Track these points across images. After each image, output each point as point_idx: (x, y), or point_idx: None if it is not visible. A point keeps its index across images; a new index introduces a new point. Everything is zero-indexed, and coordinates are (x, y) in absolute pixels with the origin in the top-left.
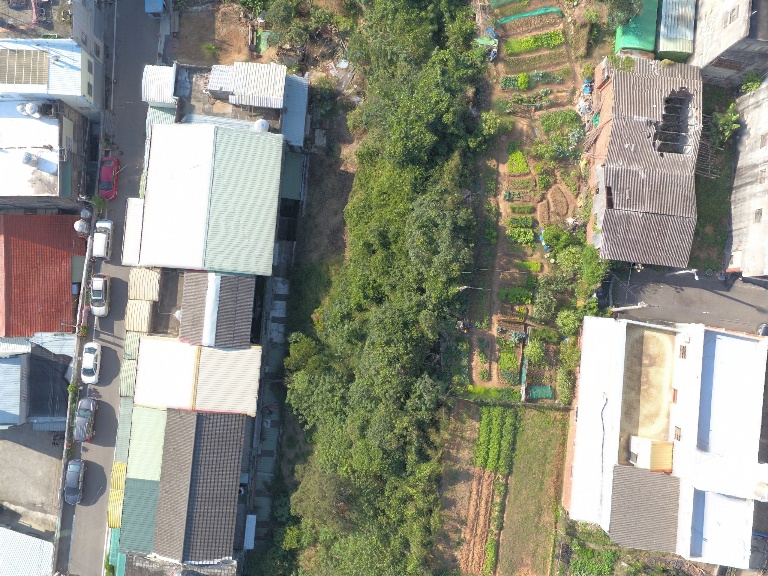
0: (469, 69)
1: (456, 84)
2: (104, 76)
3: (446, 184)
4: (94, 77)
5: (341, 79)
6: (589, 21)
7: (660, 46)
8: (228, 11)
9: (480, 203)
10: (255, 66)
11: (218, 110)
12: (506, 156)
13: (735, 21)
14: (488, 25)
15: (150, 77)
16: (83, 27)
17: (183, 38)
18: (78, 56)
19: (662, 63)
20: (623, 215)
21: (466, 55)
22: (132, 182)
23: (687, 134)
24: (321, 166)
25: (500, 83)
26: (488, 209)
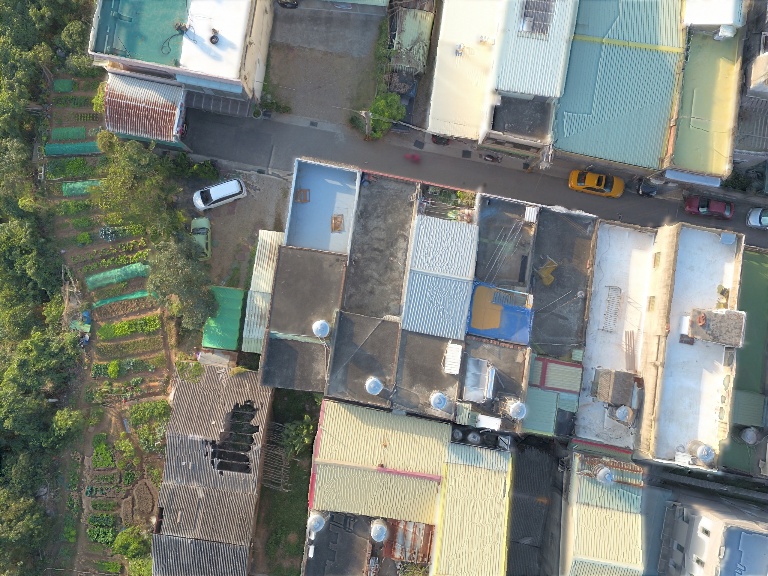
0: (57, 357)
1: (33, 378)
2: None
3: (14, 486)
4: None
5: None
6: (173, 315)
7: (242, 346)
8: None
9: (61, 498)
10: None
11: None
12: (91, 449)
13: None
14: (76, 313)
15: None
16: None
17: None
18: None
19: (231, 372)
20: (171, 541)
21: (61, 338)
22: None
23: (246, 454)
24: None
25: (91, 371)
26: (69, 505)
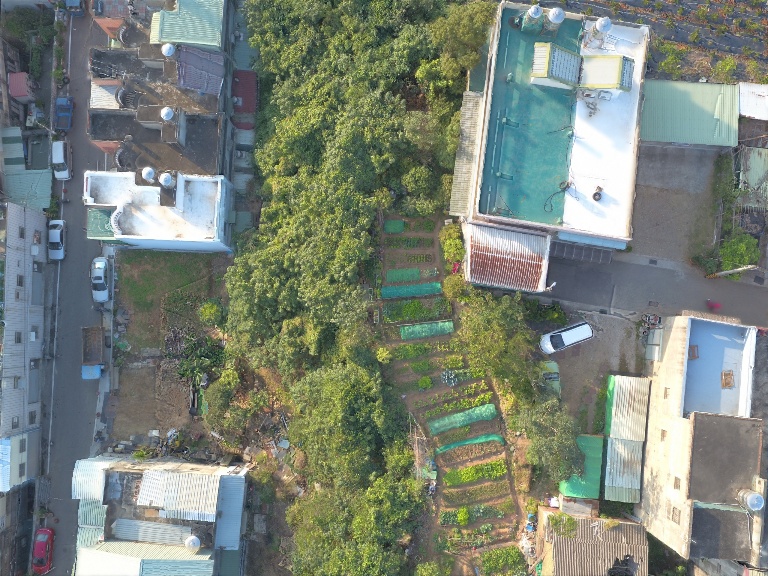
0: (406, 506)
1: (391, 531)
2: (41, 438)
3: None
4: (28, 451)
5: (282, 461)
6: (531, 464)
7: (605, 494)
8: (169, 369)
9: None
10: (187, 477)
11: (150, 514)
12: None
13: (677, 526)
14: (425, 461)
15: (80, 476)
16: (14, 411)
17: (123, 396)
18: (7, 449)
19: (605, 525)
20: None
21: (404, 484)
22: (68, 551)
23: None
24: (260, 556)
25: (439, 518)
26: None
